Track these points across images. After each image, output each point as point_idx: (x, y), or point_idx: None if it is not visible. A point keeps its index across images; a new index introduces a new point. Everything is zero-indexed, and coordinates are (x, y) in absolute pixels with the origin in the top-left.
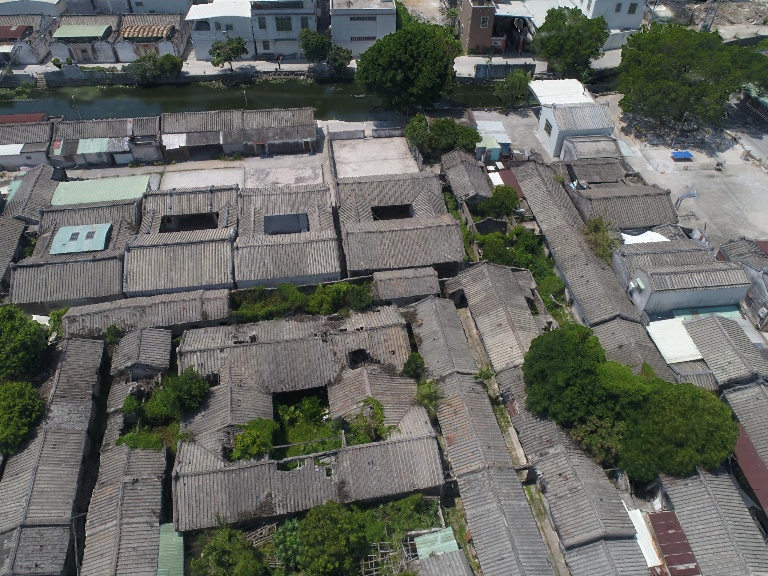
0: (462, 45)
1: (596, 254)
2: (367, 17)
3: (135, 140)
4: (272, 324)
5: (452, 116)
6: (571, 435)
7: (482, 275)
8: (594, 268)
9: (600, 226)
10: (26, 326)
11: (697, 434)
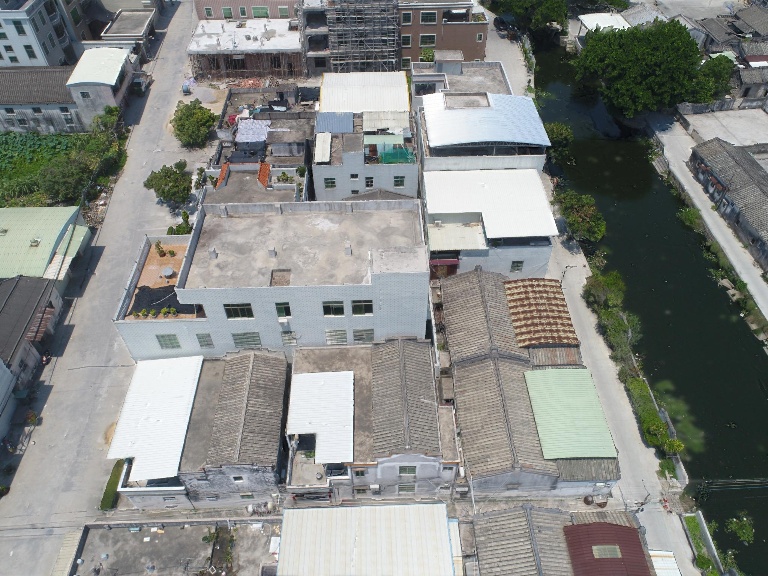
0: None
1: None
2: None
3: None
4: None
5: None
6: None
7: None
8: None
9: None
10: None
11: None
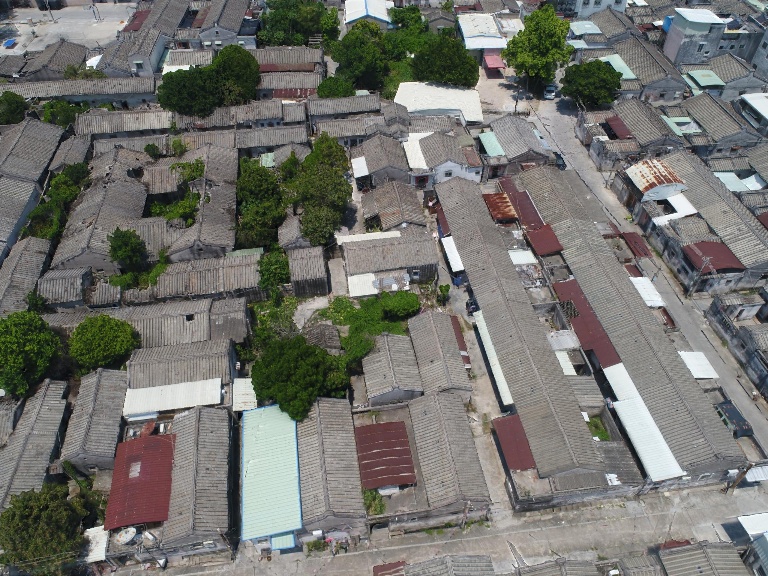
0: None
1: (98, 78)
2: None
3: None
4: (74, 217)
5: None
6: (226, 104)
7: (88, 120)
8: (112, 78)
9: (76, 68)
10: (16, 316)
11: (247, 57)
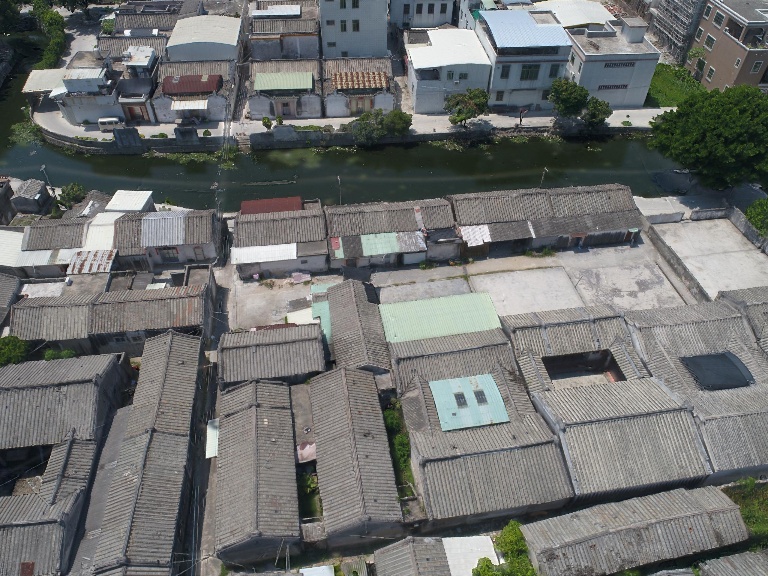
0: (709, 90)
1: None
2: (625, 63)
3: (429, 235)
4: None
5: None
6: None
7: None
8: None
9: None
10: None
11: None
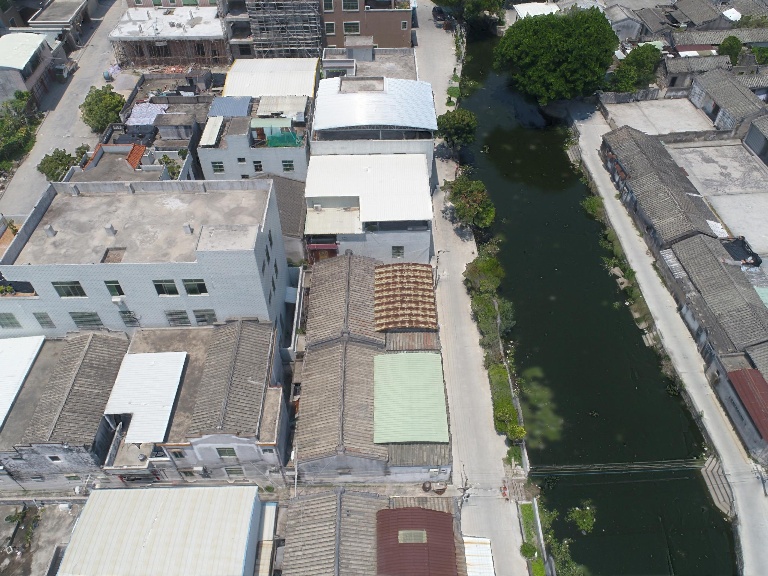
0: None
1: None
2: None
3: None
4: None
5: None
6: None
7: None
8: None
9: (750, 18)
10: None
11: None
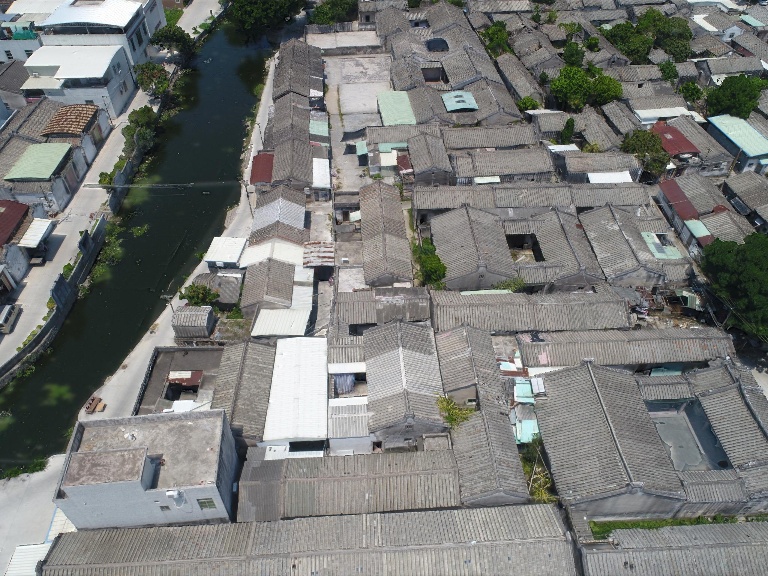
0: None
1: None
2: (153, 4)
3: None
4: None
5: (313, 3)
6: None
7: (476, 4)
8: None
9: None
10: None
11: None
